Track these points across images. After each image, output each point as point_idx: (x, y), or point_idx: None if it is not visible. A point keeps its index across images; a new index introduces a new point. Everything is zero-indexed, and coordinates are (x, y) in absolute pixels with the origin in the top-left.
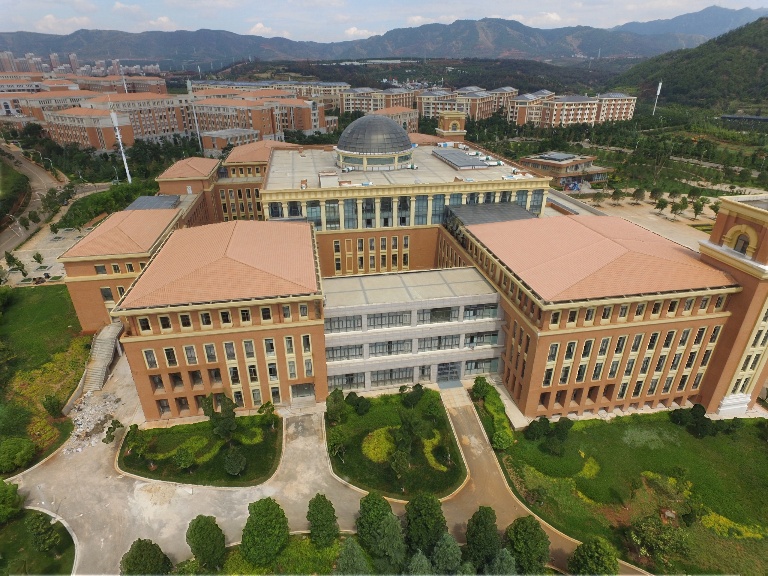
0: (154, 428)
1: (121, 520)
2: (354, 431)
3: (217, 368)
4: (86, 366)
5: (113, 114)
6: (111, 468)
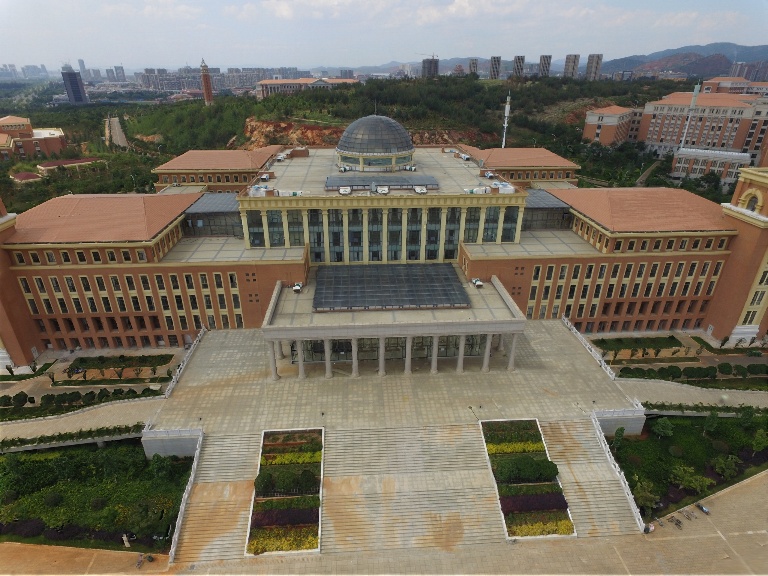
0: None
1: None
2: None
3: None
4: None
5: (507, 106)
6: None
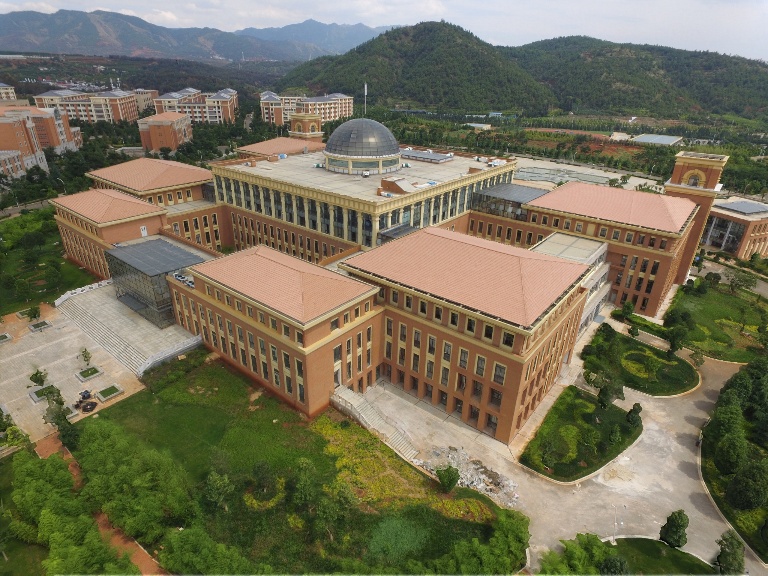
0: (530, 443)
1: (638, 504)
2: (616, 369)
3: (548, 361)
4: (386, 438)
5: None
6: (562, 487)
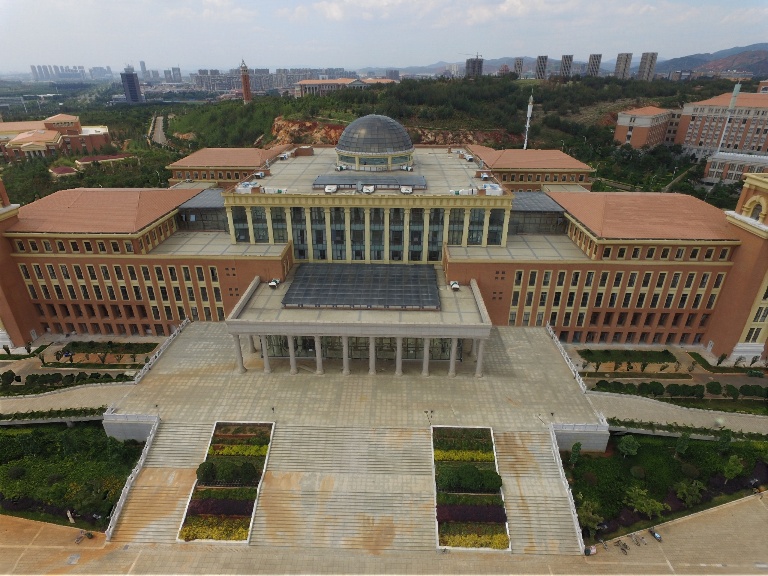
0: None
1: None
2: None
3: None
4: None
5: (529, 106)
6: None
